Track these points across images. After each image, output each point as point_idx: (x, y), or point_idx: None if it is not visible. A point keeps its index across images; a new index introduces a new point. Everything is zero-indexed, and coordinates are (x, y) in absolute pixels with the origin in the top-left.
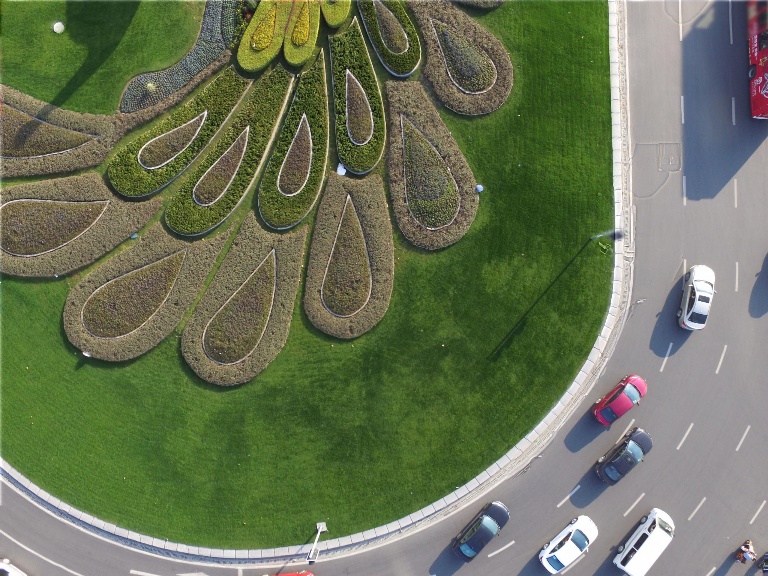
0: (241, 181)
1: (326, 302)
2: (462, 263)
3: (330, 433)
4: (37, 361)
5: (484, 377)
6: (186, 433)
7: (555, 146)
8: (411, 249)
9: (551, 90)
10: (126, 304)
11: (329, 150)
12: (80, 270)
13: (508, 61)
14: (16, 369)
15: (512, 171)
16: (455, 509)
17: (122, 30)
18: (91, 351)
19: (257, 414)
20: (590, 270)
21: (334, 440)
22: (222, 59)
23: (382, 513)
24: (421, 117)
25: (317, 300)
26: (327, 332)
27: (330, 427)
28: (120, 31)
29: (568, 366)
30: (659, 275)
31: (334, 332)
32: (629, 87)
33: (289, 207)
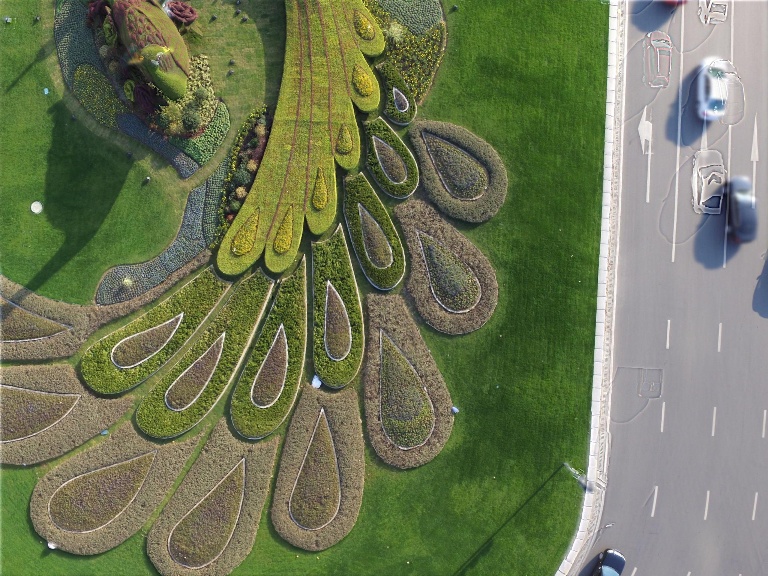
0: (214, 388)
1: (293, 515)
2: (433, 483)
3: None
4: (3, 545)
5: None
6: None
7: (535, 368)
8: (382, 466)
9: (535, 310)
10: (93, 502)
11: (305, 361)
12: (49, 461)
13: (493, 280)
14: None
15: (490, 393)
16: None
17: (101, 217)
18: (56, 543)
19: None
20: (561, 495)
21: None
22: (201, 259)
23: None
24: (401, 335)
25: (285, 512)
26: (293, 544)
27: None
28: (99, 218)
29: None
30: (630, 500)
31: (300, 545)
32: (616, 308)
33: (261, 419)
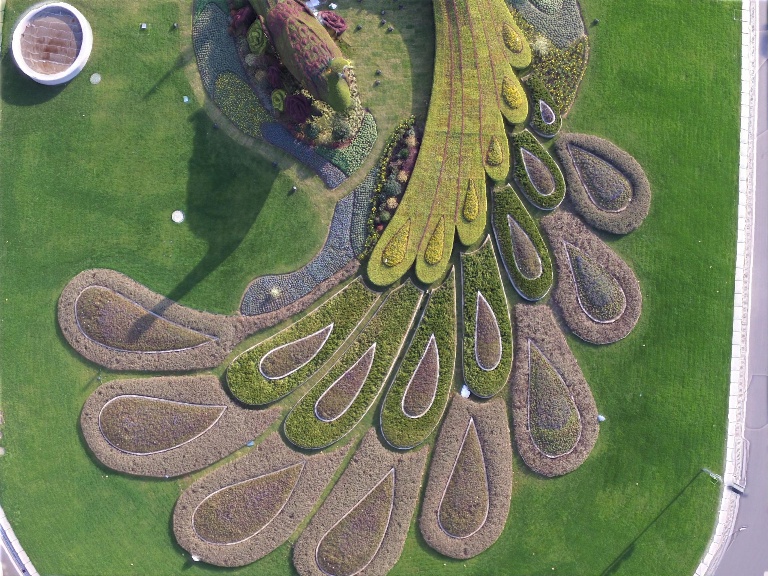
0: (365, 399)
1: (442, 523)
2: (578, 490)
3: None
4: (142, 558)
5: None
6: None
7: (676, 377)
8: (529, 474)
9: (677, 320)
10: (240, 514)
11: (454, 371)
12: (192, 473)
13: (638, 291)
14: (120, 564)
15: (633, 401)
16: None
17: (246, 227)
18: (201, 556)
19: None
20: (699, 500)
21: None
22: (351, 270)
23: None
24: (549, 345)
25: (434, 521)
26: (441, 552)
27: None
28: (243, 228)
29: None
30: (763, 504)
31: (448, 553)
32: (750, 317)
33: (413, 429)
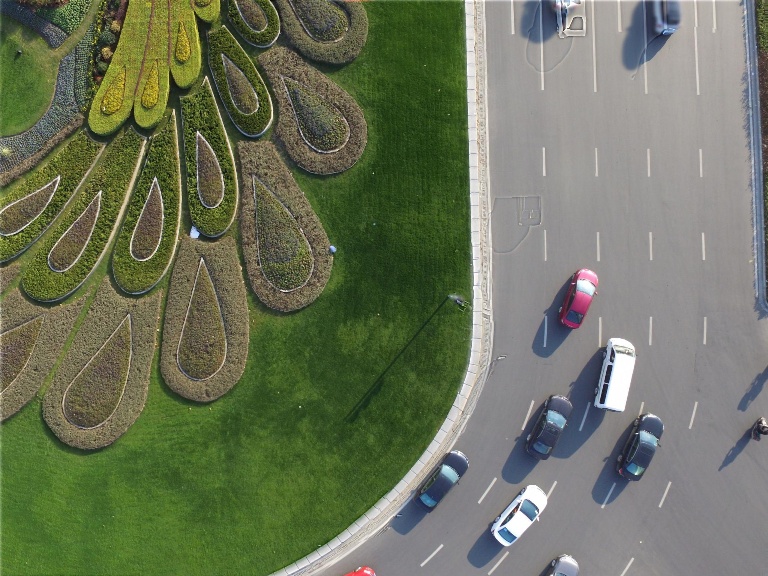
0: (94, 247)
1: (182, 366)
2: (317, 324)
3: (191, 495)
4: None
5: (341, 438)
6: (51, 495)
7: (411, 203)
8: (266, 311)
9: (406, 146)
10: None
11: (182, 213)
12: None
13: (361, 118)
14: None
15: (367, 230)
16: (320, 566)
17: None
18: None
19: (119, 477)
20: (448, 328)
21: (195, 501)
22: (74, 123)
23: (246, 572)
24: (272, 178)
25: (173, 364)
26: (184, 396)
27: (190, 489)
28: None
29: (427, 425)
30: (520, 331)
31: (190, 396)
32: (489, 140)
33: (142, 272)
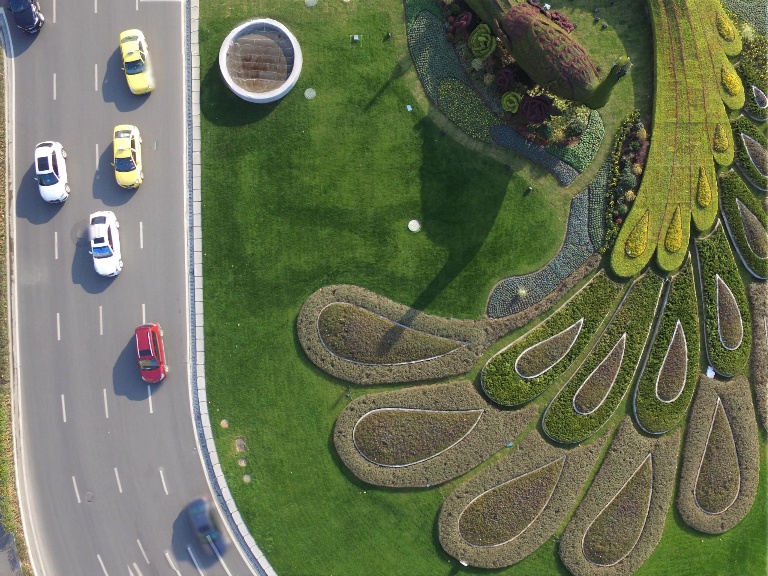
0: (620, 389)
1: (699, 501)
2: None
3: None
4: (407, 570)
5: None
6: None
7: None
8: None
9: None
10: (507, 514)
11: (699, 353)
12: (453, 479)
13: None
14: None
15: None
16: None
17: (485, 231)
18: (469, 560)
19: None
20: None
21: None
22: (594, 264)
23: None
24: None
25: (691, 500)
26: (700, 530)
27: None
28: (483, 232)
29: None
30: None
31: (707, 529)
32: None
33: (668, 414)
